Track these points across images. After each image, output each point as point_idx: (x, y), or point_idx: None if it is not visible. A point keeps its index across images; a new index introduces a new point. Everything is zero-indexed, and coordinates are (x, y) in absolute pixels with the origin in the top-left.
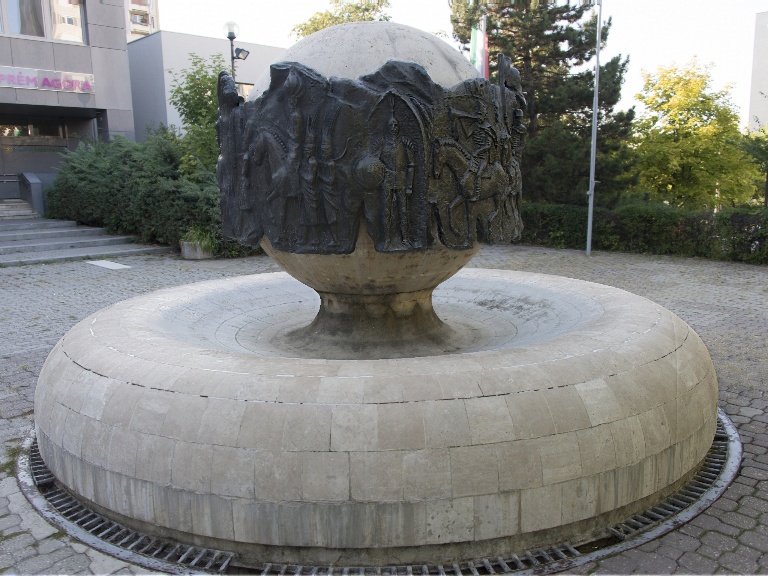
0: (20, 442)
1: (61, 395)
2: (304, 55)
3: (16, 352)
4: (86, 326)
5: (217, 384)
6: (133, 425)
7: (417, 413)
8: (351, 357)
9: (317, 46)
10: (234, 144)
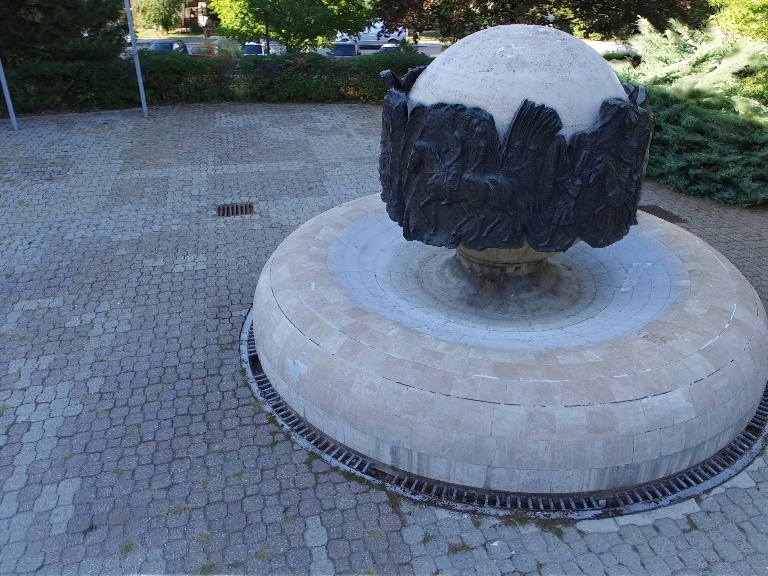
0: (486, 518)
1: (640, 428)
2: (584, 81)
3: (63, 518)
4: (508, 383)
5: (727, 351)
6: (719, 403)
7: (762, 311)
8: (568, 301)
9: (585, 71)
10: (555, 171)
